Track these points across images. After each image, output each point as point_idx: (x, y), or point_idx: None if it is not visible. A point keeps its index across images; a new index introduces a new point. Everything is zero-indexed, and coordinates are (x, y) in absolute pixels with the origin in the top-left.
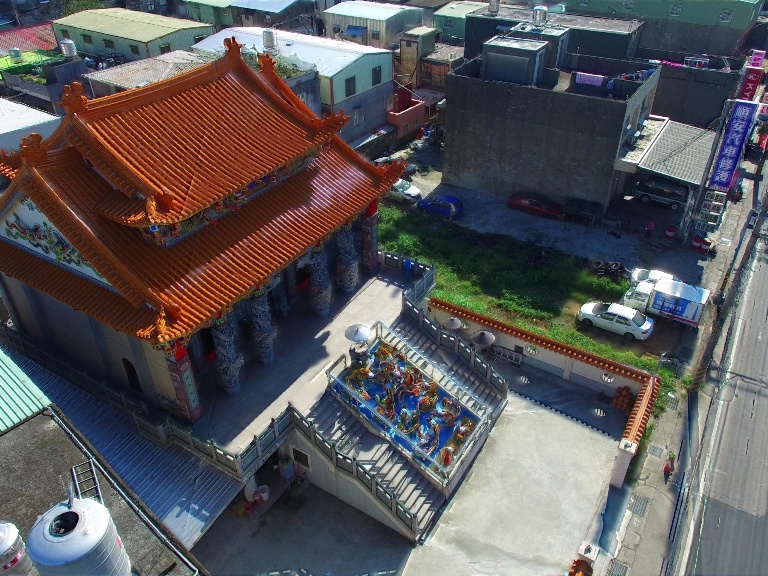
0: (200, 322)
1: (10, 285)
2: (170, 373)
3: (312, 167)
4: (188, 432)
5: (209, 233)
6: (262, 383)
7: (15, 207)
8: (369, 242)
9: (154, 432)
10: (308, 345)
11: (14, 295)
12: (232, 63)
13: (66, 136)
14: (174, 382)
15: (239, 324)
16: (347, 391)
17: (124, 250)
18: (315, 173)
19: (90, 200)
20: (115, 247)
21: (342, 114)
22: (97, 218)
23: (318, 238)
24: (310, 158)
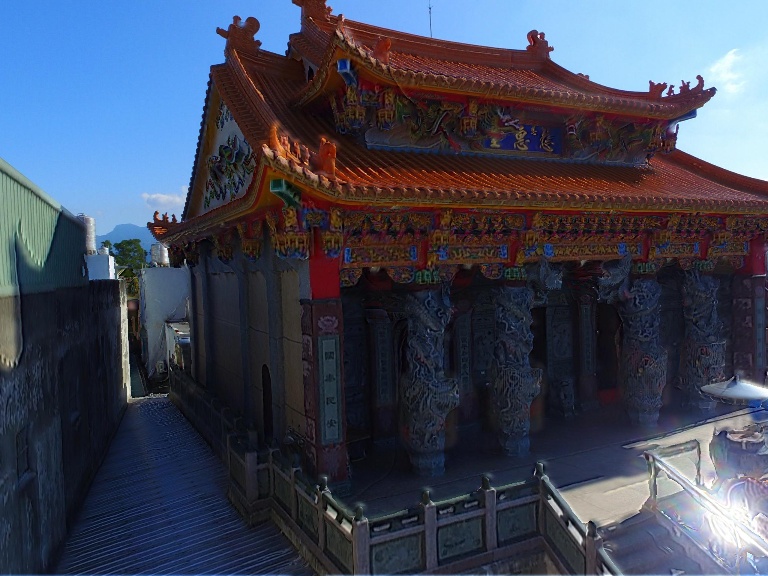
0: (367, 190)
1: (199, 308)
2: (302, 341)
3: (641, 169)
4: (291, 469)
5: (444, 158)
6: (491, 476)
7: (213, 142)
8: (747, 331)
9: (242, 477)
10: (606, 451)
11: (200, 325)
12: (535, 62)
13: (291, 39)
14: (304, 364)
15: (475, 388)
16: (704, 504)
17: (300, 134)
18: (646, 173)
19: (288, 98)
20: (289, 129)
21: (700, 85)
22: (285, 110)
23: (645, 200)
24: (639, 159)
